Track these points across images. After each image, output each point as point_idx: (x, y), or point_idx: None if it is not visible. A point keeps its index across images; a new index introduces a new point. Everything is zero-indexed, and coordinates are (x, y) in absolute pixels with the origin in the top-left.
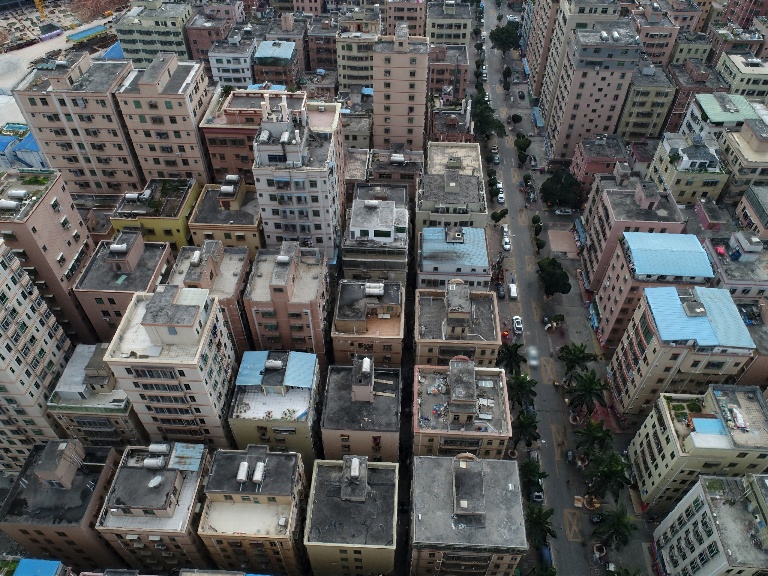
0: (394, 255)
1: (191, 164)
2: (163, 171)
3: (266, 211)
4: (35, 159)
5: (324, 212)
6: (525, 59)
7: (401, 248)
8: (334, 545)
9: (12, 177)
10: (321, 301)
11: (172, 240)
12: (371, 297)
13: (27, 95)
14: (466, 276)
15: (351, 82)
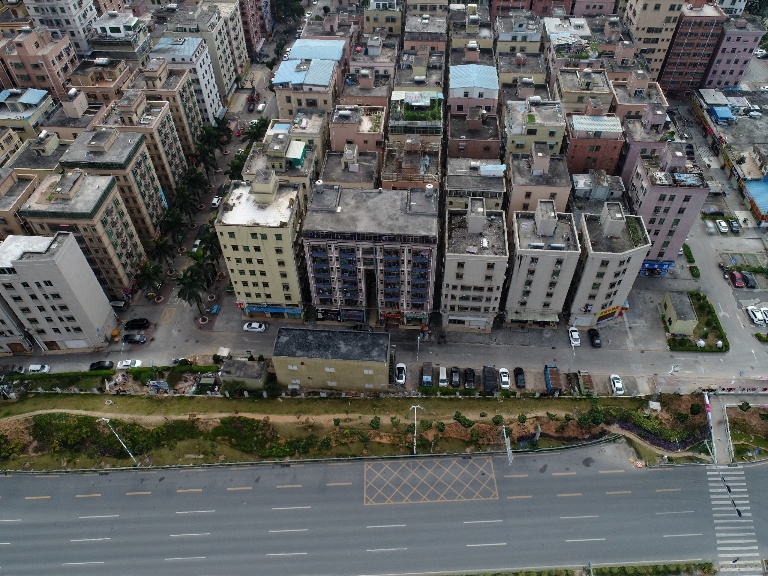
0: (125, 46)
1: None
2: None
3: (30, 9)
4: None
5: (67, 9)
6: None
7: (128, 40)
8: (19, 169)
9: None
10: (58, 62)
11: None
12: (99, 66)
13: None
14: (179, 64)
15: None
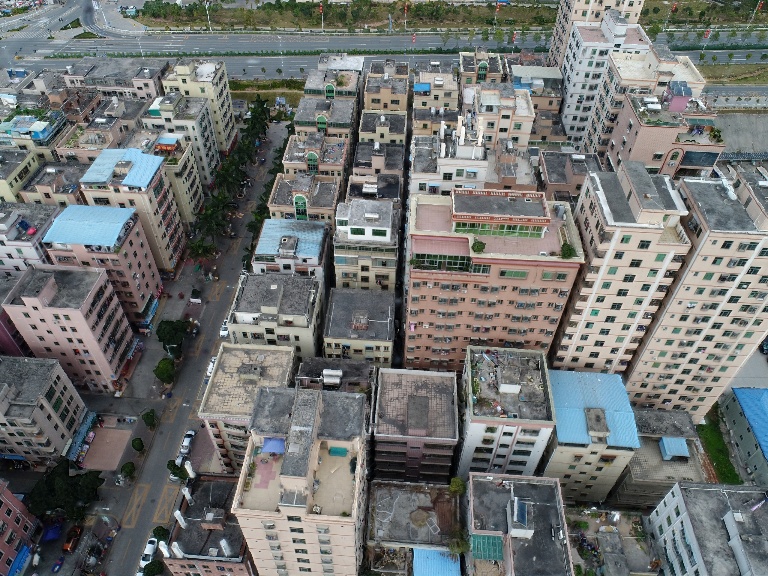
0: None
1: None
2: None
3: None
4: None
5: None
6: None
7: None
8: (392, 111)
9: None
10: None
11: None
12: None
13: None
14: None
15: None
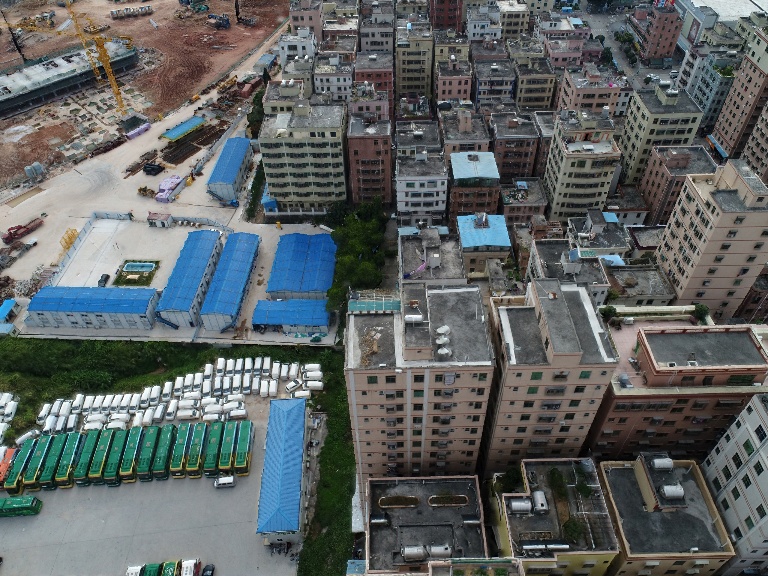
0: None
1: (572, 430)
2: (524, 438)
3: None
4: (183, 319)
5: None
6: (712, 137)
7: None
8: None
9: (439, 571)
10: None
11: (587, 569)
12: None
13: (368, 373)
14: None
15: (572, 200)
